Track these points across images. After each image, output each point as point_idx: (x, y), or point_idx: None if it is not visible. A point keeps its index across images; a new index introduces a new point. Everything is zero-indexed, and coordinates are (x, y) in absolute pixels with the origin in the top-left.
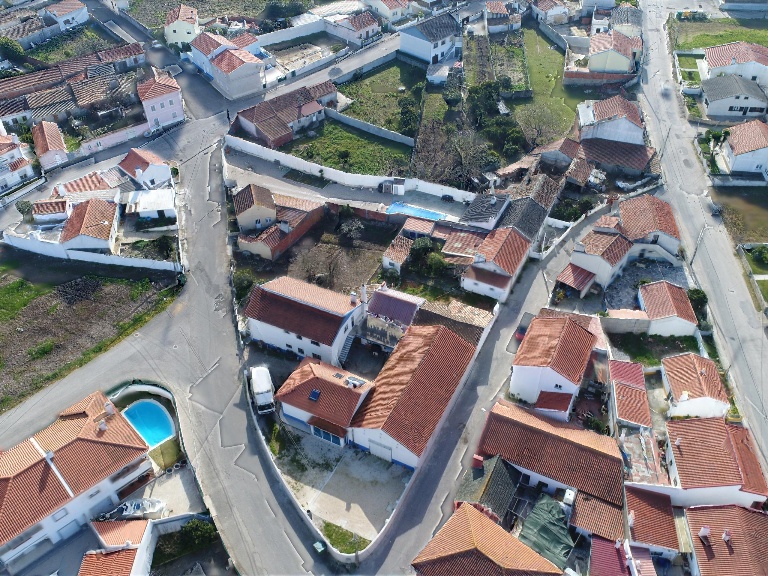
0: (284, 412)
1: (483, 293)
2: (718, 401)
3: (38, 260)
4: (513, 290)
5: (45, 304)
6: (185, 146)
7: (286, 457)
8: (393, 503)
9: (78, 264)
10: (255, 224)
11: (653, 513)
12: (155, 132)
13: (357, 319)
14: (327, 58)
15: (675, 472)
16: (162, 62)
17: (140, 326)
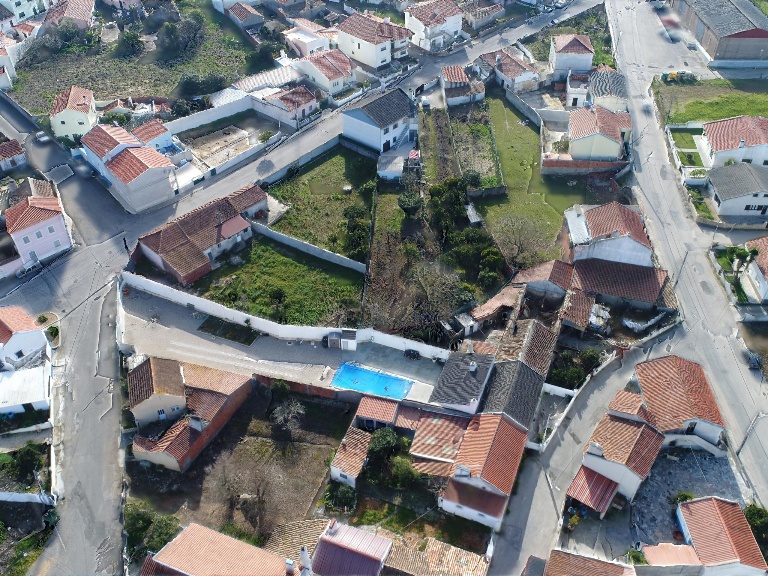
0: None
1: (469, 517)
2: None
3: None
4: (509, 509)
5: None
6: (70, 288)
7: None
8: None
9: None
10: (157, 415)
11: None
12: (30, 270)
13: None
14: (255, 148)
15: None
16: (48, 161)
17: None
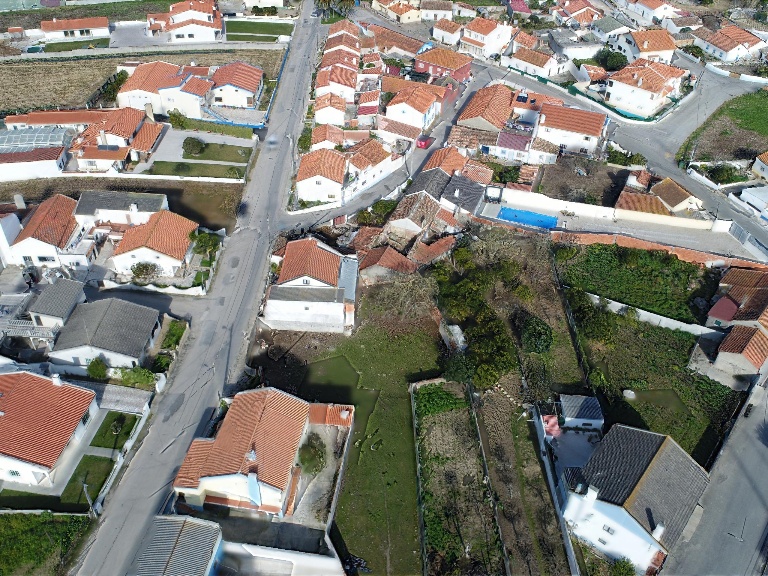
0: None
1: None
2: None
3: None
4: None
5: None
6: None
7: None
8: None
9: None
10: None
11: None
12: None
13: None
14: None
15: None
16: None
17: None
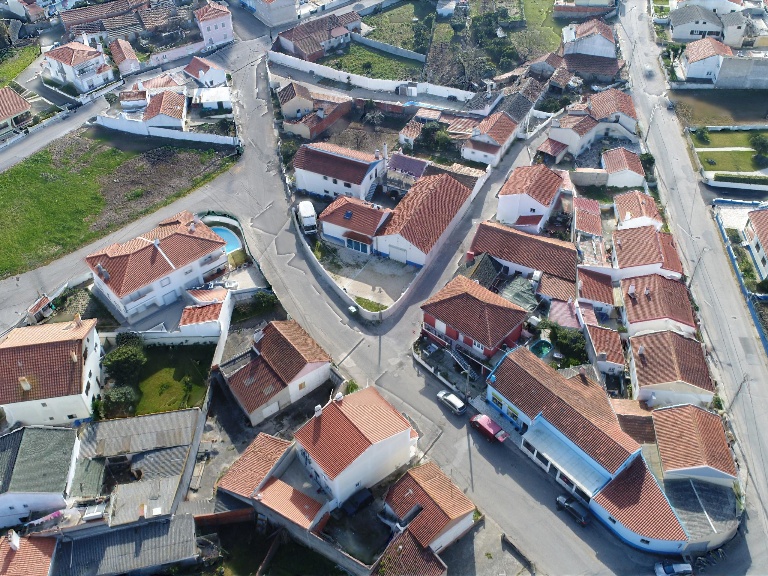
0: (324, 233)
1: (479, 160)
2: (653, 219)
3: (125, 136)
4: (503, 159)
5: (134, 164)
6: (235, 60)
7: (326, 260)
8: (407, 285)
9: (157, 139)
10: (296, 113)
11: (597, 284)
12: (210, 49)
13: (379, 172)
14: None
15: (616, 262)
16: None
17: (209, 181)
